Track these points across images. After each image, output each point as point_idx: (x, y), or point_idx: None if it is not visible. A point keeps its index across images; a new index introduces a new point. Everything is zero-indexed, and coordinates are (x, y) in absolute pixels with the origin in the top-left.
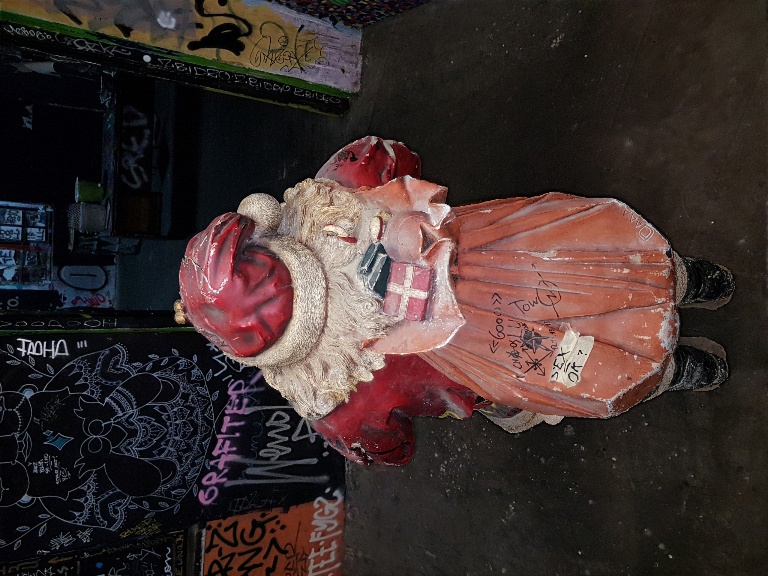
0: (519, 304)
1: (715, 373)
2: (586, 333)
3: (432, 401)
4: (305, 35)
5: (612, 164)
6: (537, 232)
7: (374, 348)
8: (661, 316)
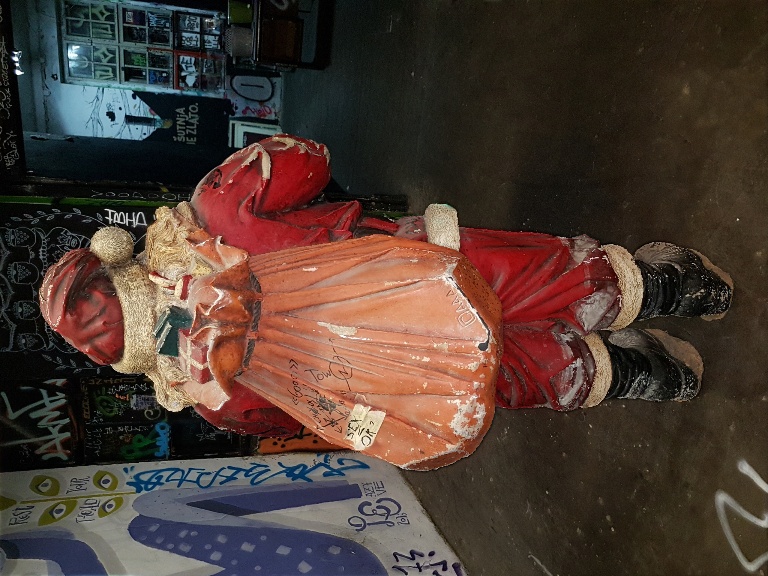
0: (314, 372)
1: (675, 392)
2: (381, 407)
3: None
4: None
5: (663, 112)
6: (344, 305)
7: (183, 387)
8: (455, 408)
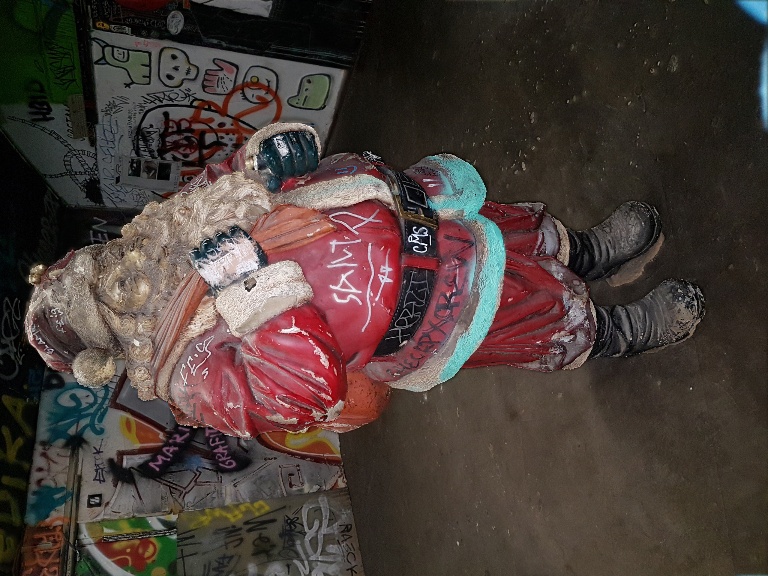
0: None
1: None
2: None
3: None
4: None
5: None
6: None
7: None
8: None
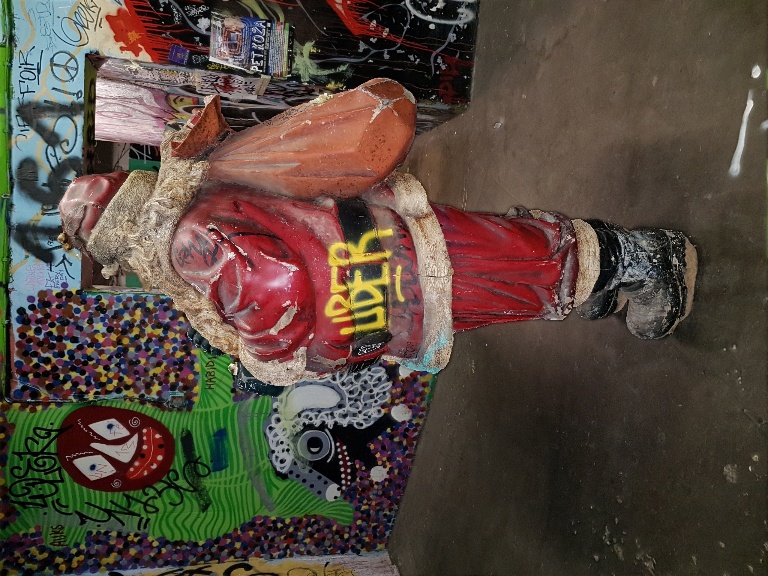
0: None
1: None
2: None
3: (292, 225)
4: (332, 567)
5: (538, 336)
6: None
7: None
8: None
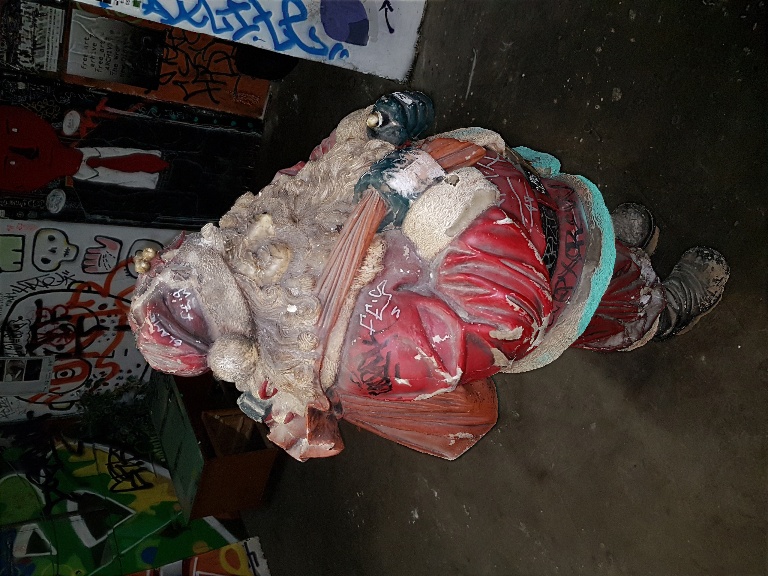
0: None
1: None
2: None
3: None
4: None
5: None
6: None
7: None
8: None
